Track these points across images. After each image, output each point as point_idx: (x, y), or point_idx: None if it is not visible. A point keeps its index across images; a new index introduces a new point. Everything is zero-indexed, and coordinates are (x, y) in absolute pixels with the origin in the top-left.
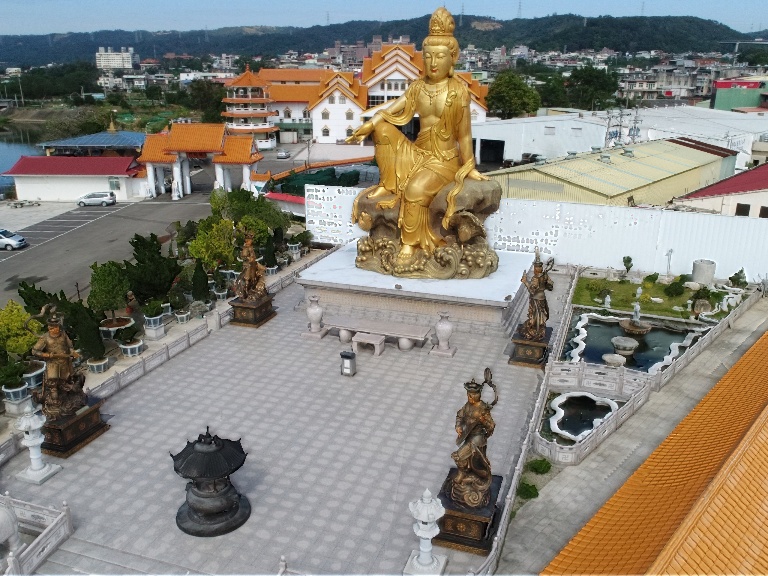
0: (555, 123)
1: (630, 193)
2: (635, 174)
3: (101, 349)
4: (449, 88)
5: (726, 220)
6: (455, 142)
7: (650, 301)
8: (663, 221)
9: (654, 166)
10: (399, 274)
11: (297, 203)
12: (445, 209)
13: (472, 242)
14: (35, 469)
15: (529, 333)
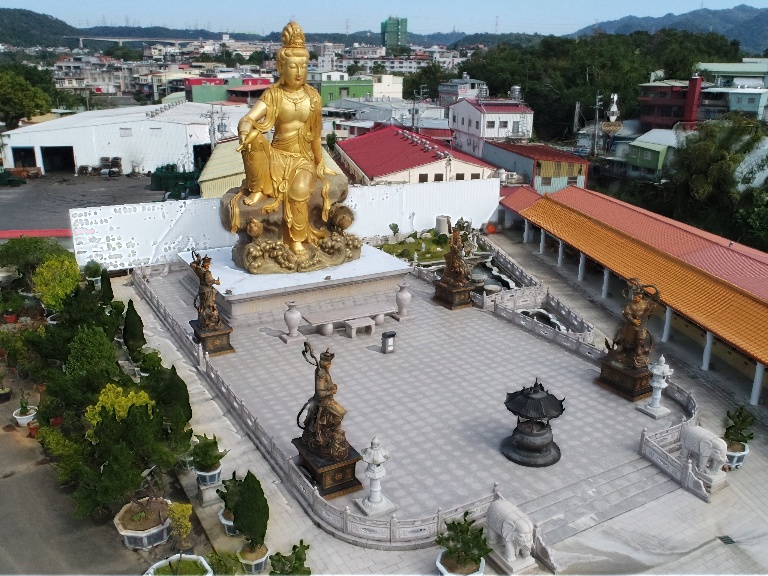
0: (131, 124)
1: None
2: None
3: (191, 411)
4: (310, 95)
5: (443, 185)
6: None
7: (437, 251)
8: (405, 192)
9: None
10: (306, 269)
11: None
12: (322, 204)
13: None
14: (380, 501)
15: (463, 282)
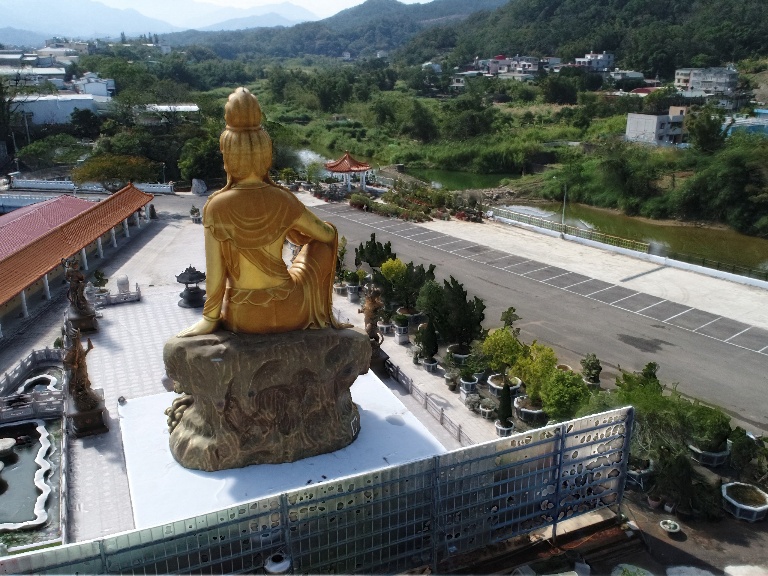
0: None
1: None
2: None
3: None
4: None
5: None
6: None
7: None
8: None
9: None
10: None
11: None
12: None
13: None
14: None
15: None
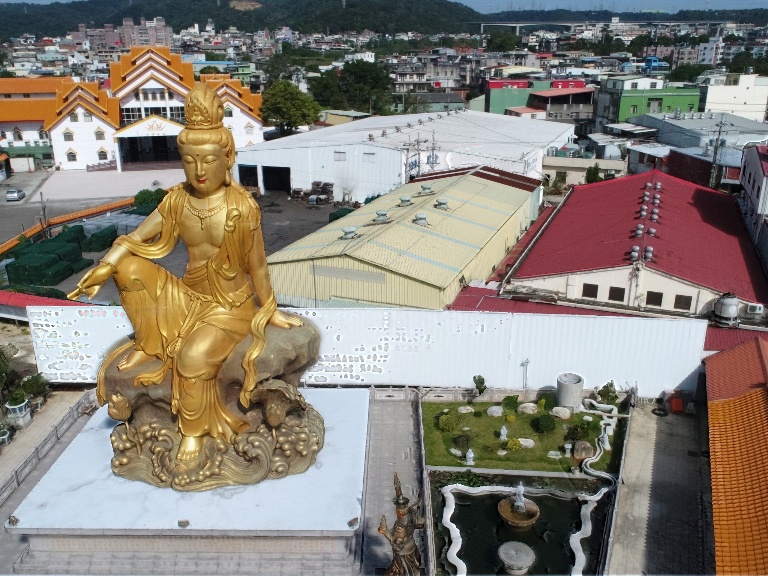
0: (345, 148)
1: (461, 273)
2: (458, 240)
3: None
4: (228, 204)
5: (587, 322)
6: (245, 276)
7: (520, 448)
8: (515, 326)
9: (473, 221)
10: (182, 487)
11: (25, 308)
12: (242, 379)
13: (286, 413)
14: None
15: None
